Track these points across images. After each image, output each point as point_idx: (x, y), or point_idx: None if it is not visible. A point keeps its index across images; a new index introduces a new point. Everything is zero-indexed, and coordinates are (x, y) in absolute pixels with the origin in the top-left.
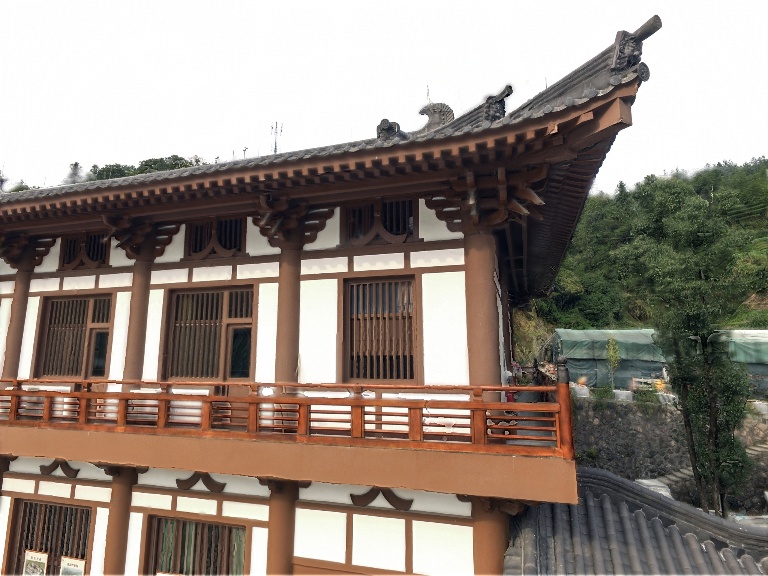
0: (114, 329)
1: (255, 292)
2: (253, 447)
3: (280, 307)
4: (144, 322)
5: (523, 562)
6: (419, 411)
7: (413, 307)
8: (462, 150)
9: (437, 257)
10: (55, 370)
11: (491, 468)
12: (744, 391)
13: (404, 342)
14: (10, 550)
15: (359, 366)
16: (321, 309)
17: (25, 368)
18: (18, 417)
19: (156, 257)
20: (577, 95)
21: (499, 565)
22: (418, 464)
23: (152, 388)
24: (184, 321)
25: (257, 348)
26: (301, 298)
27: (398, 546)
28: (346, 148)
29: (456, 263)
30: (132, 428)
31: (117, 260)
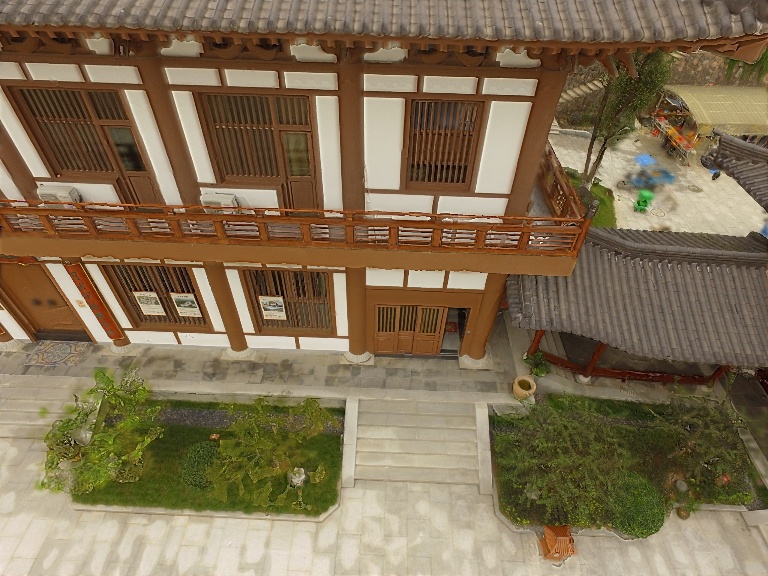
0: (140, 132)
1: (311, 104)
2: (354, 253)
3: (343, 123)
4: (178, 127)
5: (522, 290)
6: (485, 232)
7: (475, 127)
8: (601, 50)
9: (510, 86)
10: (76, 165)
11: (526, 261)
12: (662, 83)
13: (460, 154)
14: (119, 293)
15: (419, 173)
16: (387, 128)
17: (36, 165)
18: (100, 232)
19: (162, 47)
20: (737, 5)
21: (502, 285)
22: (478, 260)
23: (213, 188)
24: (226, 124)
25: (321, 158)
26: (365, 115)
27: (439, 278)
28: (482, 34)
29: (527, 94)
30: (236, 241)
31: (100, 45)
